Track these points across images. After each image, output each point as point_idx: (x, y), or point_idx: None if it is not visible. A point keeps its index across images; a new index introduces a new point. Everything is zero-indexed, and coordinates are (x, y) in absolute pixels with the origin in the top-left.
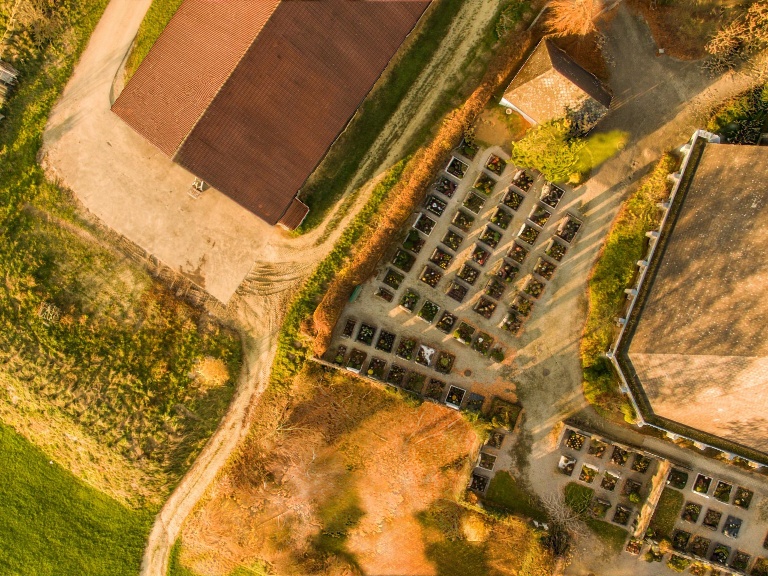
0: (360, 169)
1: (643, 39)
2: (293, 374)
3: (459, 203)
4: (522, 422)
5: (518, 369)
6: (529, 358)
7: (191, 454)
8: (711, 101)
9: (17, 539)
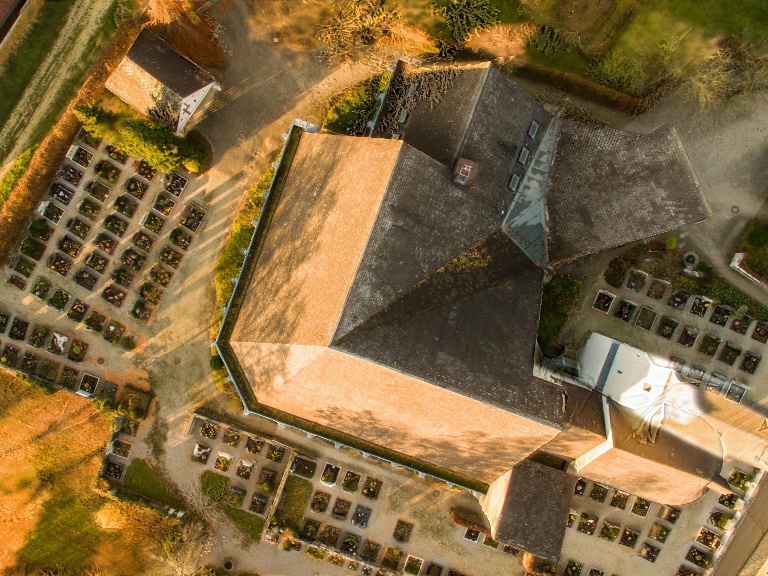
0: None
1: (260, 28)
2: None
3: (86, 192)
4: (156, 410)
5: (150, 357)
6: (160, 346)
7: None
8: (330, 91)
9: None
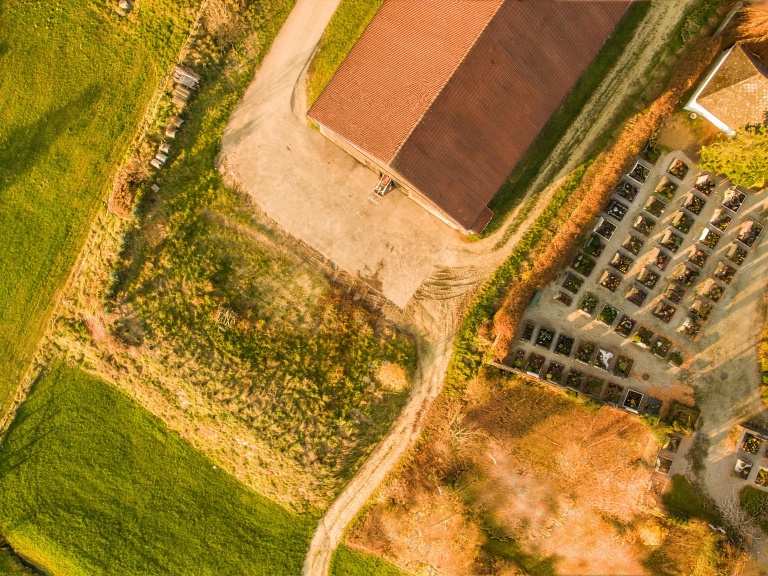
0: (541, 173)
1: None
2: (468, 378)
3: (640, 207)
4: (699, 426)
5: (696, 373)
6: (707, 362)
7: (360, 459)
8: None
9: (177, 544)
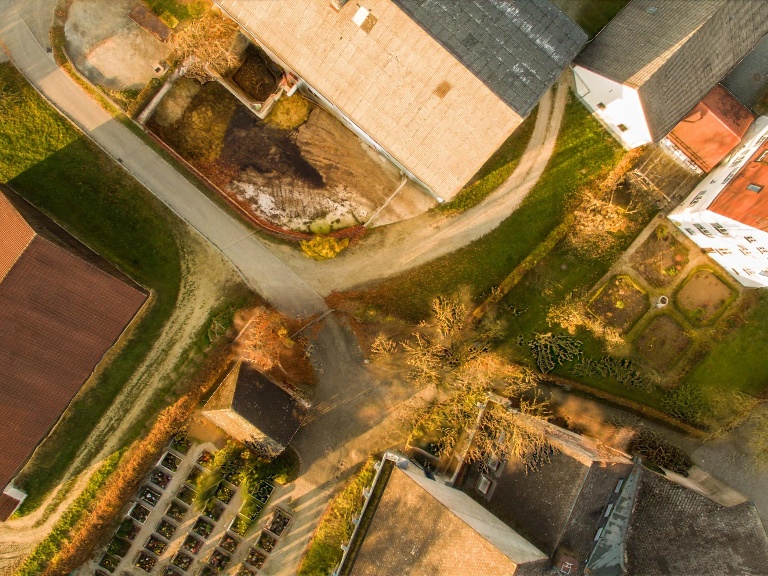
0: (77, 457)
1: (351, 348)
2: None
3: (173, 494)
4: None
5: None
6: None
7: None
8: (416, 408)
9: None
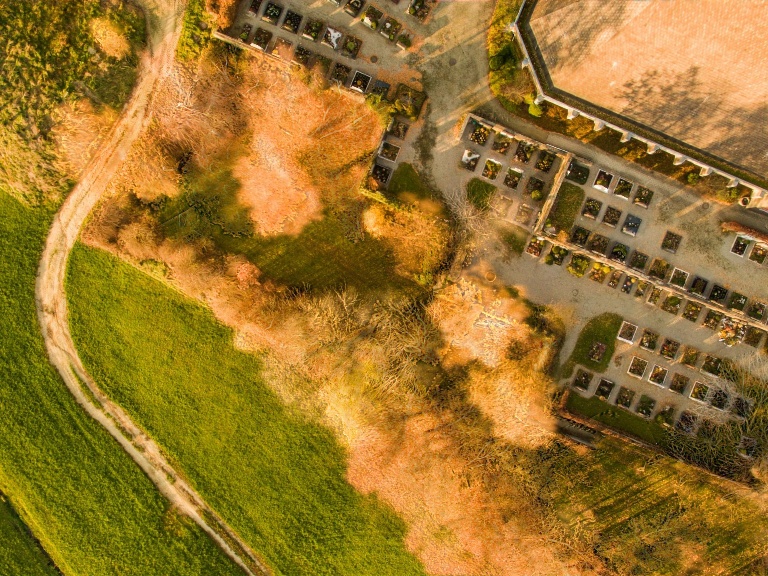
0: None
1: None
2: (197, 56)
3: None
4: (427, 113)
5: (425, 57)
6: (436, 46)
7: (91, 144)
8: None
9: None
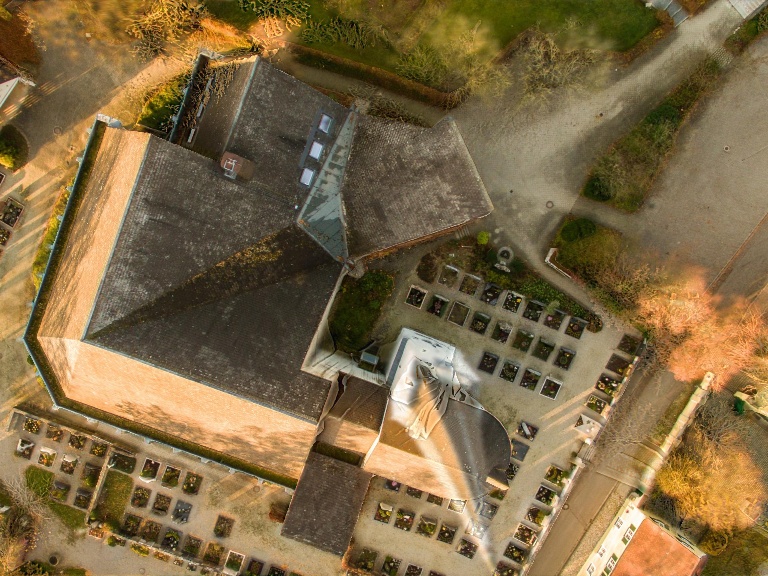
0: None
1: (73, 23)
2: None
3: None
4: None
5: None
6: None
7: None
8: (145, 86)
9: None
